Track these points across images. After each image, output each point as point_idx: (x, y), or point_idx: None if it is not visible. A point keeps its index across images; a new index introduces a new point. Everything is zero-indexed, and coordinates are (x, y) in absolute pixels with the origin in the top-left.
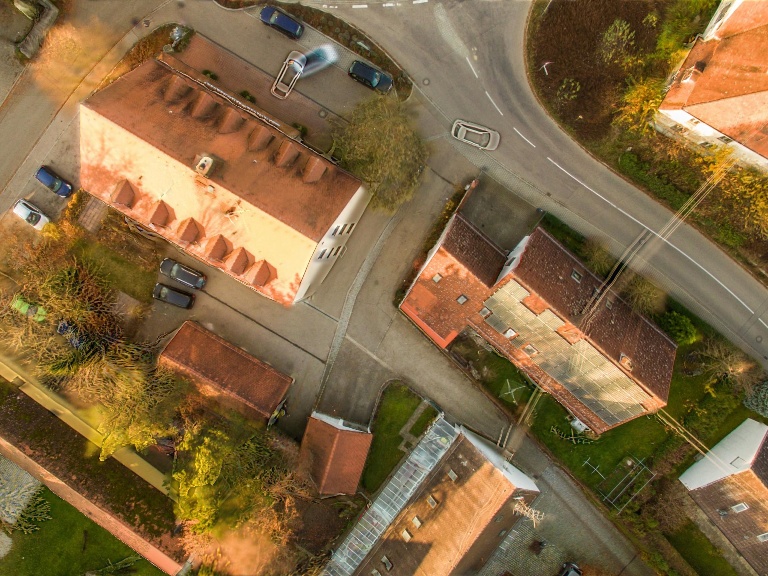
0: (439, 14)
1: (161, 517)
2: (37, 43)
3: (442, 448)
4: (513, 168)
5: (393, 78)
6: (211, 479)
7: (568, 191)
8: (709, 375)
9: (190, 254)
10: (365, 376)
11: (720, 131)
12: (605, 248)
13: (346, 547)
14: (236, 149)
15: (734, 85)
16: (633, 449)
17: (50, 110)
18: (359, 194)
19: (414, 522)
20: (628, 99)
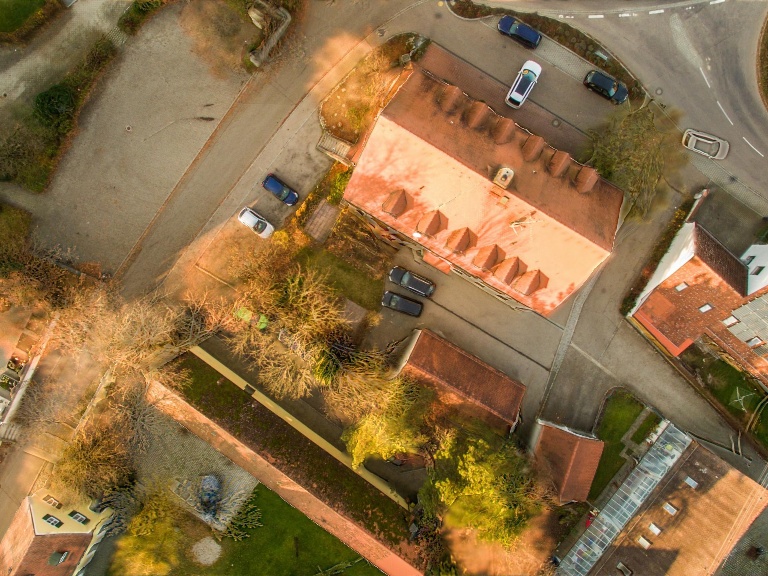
0: (675, 24)
1: (396, 525)
2: (267, 52)
3: (667, 455)
4: (741, 177)
5: (627, 88)
6: (489, 488)
7: None
8: None
9: (429, 263)
10: (589, 383)
11: None
12: None
13: (575, 554)
14: (515, 160)
15: None
16: None
17: (276, 118)
18: (625, 204)
19: (651, 529)
20: None
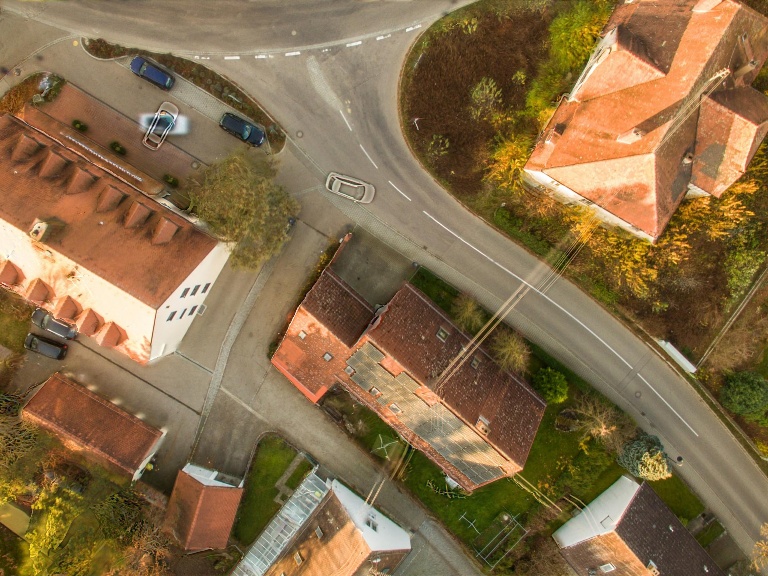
0: (312, 67)
1: (27, 570)
2: None
3: (316, 502)
4: (389, 221)
5: (266, 130)
6: (54, 543)
7: (445, 245)
8: (583, 432)
9: None
10: (240, 428)
11: (580, 194)
12: (482, 302)
13: None
14: (82, 210)
15: (588, 150)
16: (509, 504)
17: None
18: (213, 254)
19: None
20: (497, 156)
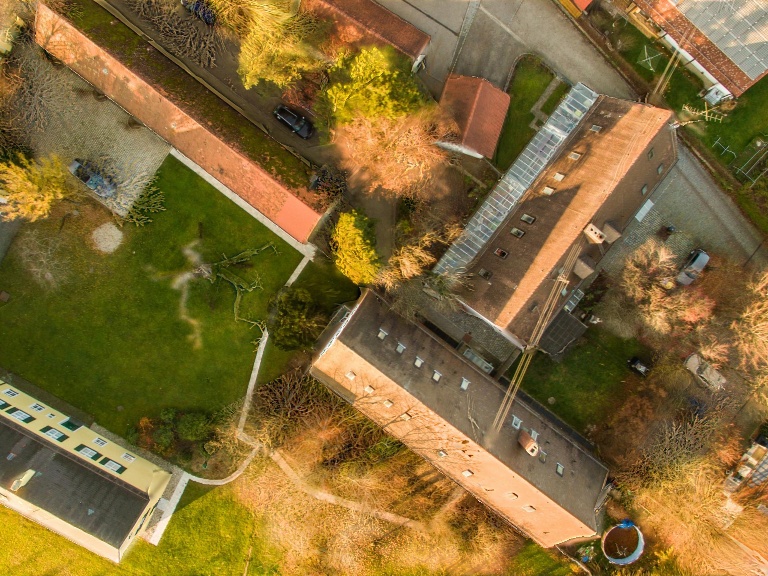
0: None
1: (296, 174)
2: None
3: (576, 121)
4: None
5: None
6: (378, 71)
7: None
8: None
9: None
10: (498, 49)
11: None
12: None
13: (480, 215)
14: None
15: None
16: (763, 128)
17: None
18: None
19: (556, 177)
20: None
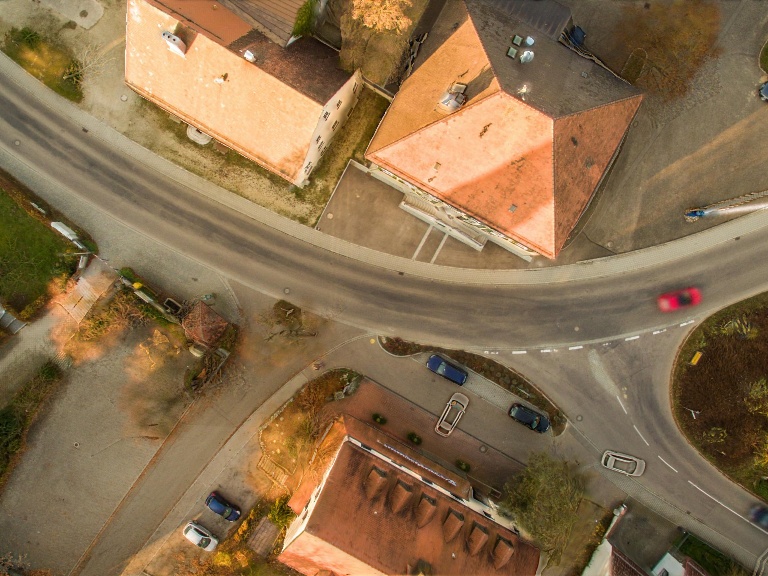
0: (593, 359)
1: None
2: None
3: None
4: (657, 491)
5: (549, 417)
6: None
7: (706, 509)
8: None
9: None
10: None
11: None
12: (739, 560)
13: None
14: (436, 544)
15: None
16: None
17: (219, 439)
18: (540, 566)
19: None
20: None
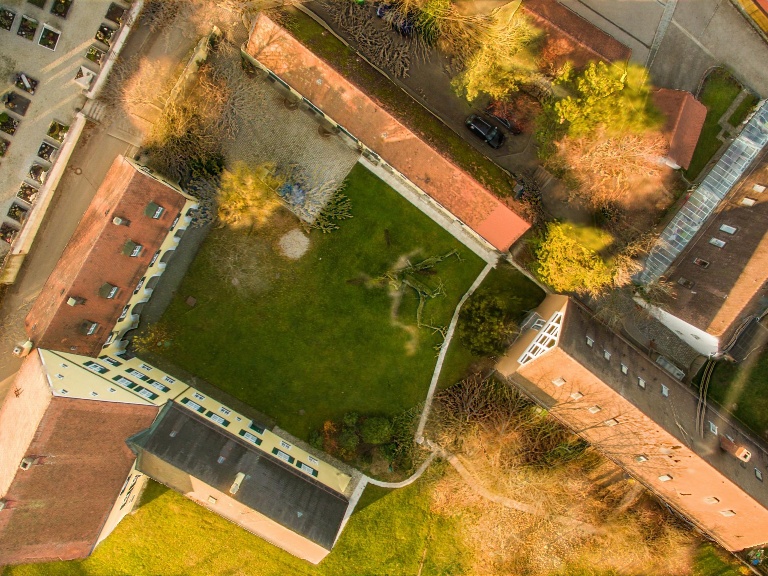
0: None
1: (501, 184)
2: None
3: (765, 133)
4: None
5: None
6: (618, 86)
7: None
8: None
9: None
10: (688, 62)
11: None
12: None
13: (675, 225)
14: None
15: None
16: None
17: None
18: None
19: (755, 189)
20: None
